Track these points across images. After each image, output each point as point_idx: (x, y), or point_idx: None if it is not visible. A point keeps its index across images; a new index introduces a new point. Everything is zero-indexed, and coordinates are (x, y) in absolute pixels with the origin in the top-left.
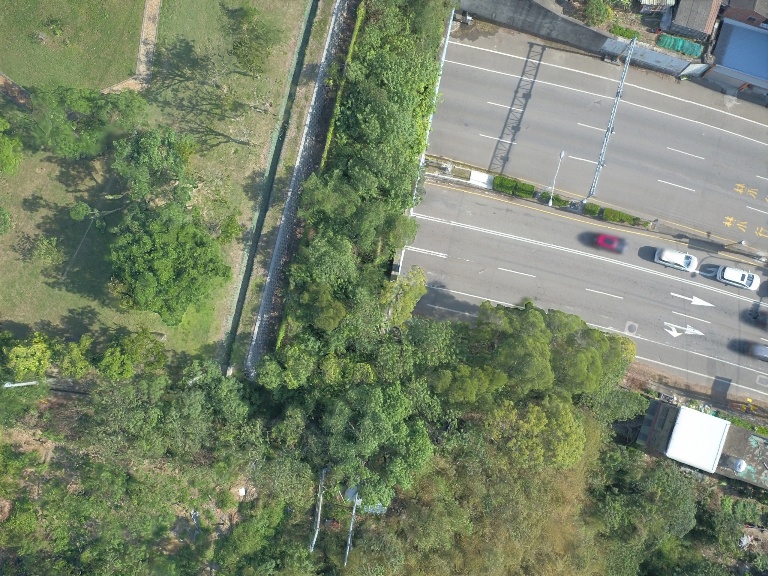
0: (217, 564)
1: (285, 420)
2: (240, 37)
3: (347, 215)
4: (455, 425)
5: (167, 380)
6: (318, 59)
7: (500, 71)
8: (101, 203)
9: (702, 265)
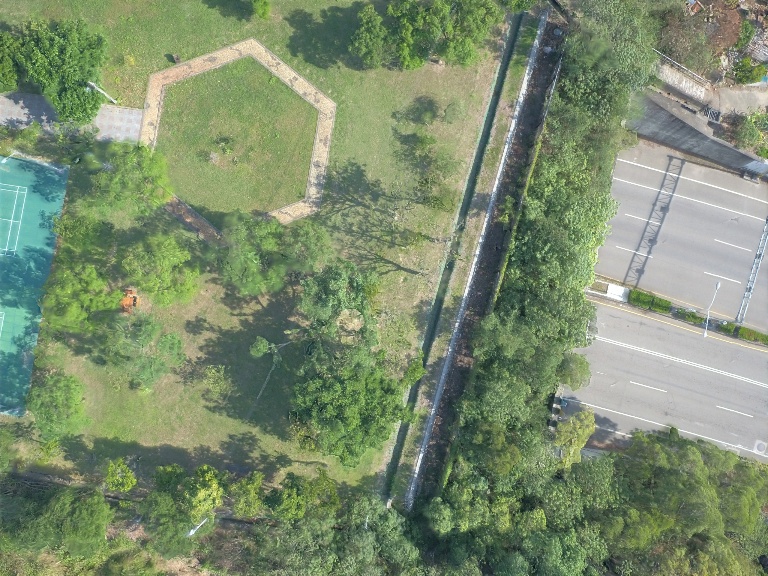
0: None
1: (463, 568)
2: (412, 163)
3: (527, 358)
4: (629, 575)
5: (337, 518)
6: (489, 188)
7: (639, 183)
8: (266, 328)
9: None
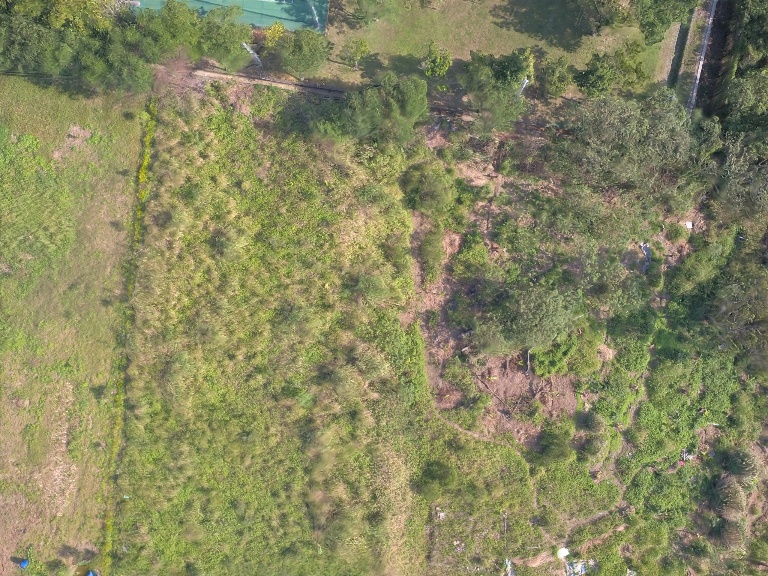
0: (667, 294)
1: None
2: None
3: None
4: None
5: (638, 103)
6: None
7: None
8: None
9: None
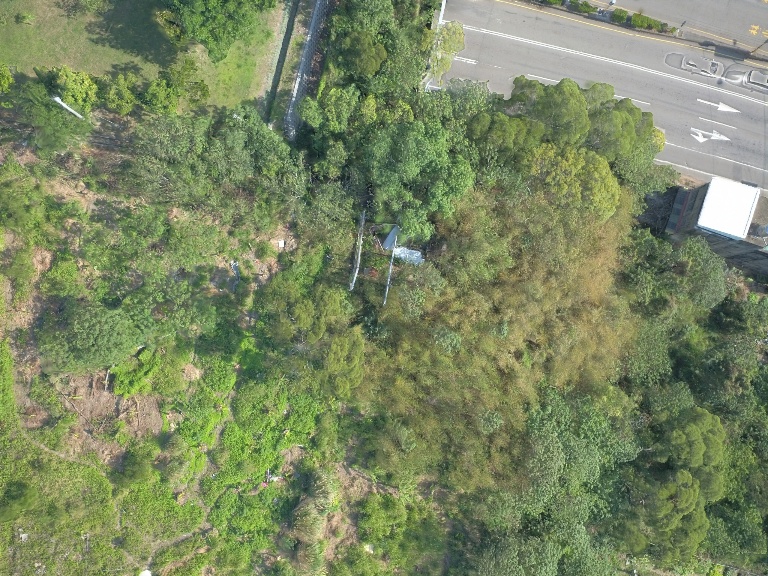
0: (256, 313)
1: (328, 151)
2: None
3: None
4: (495, 163)
5: (211, 121)
6: None
7: None
8: None
9: (728, 72)
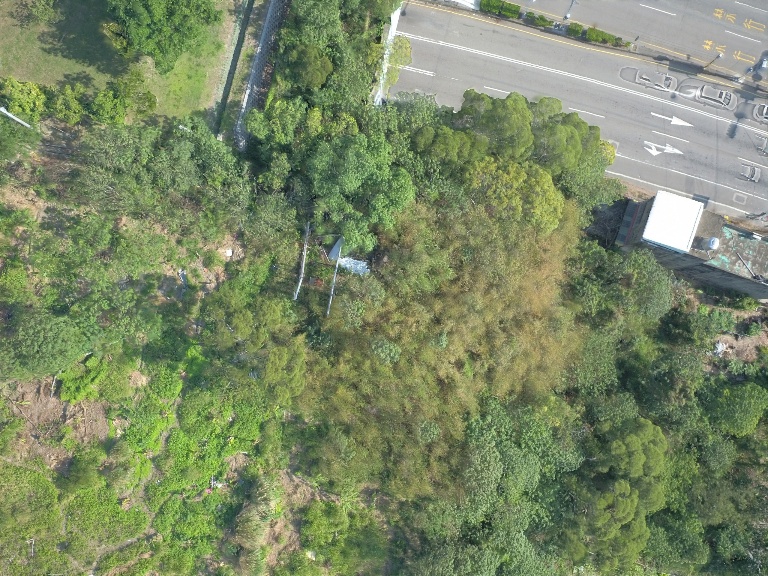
0: (203, 321)
1: (272, 162)
2: None
3: None
4: (437, 175)
5: None
6: None
7: None
8: None
9: (682, 86)
